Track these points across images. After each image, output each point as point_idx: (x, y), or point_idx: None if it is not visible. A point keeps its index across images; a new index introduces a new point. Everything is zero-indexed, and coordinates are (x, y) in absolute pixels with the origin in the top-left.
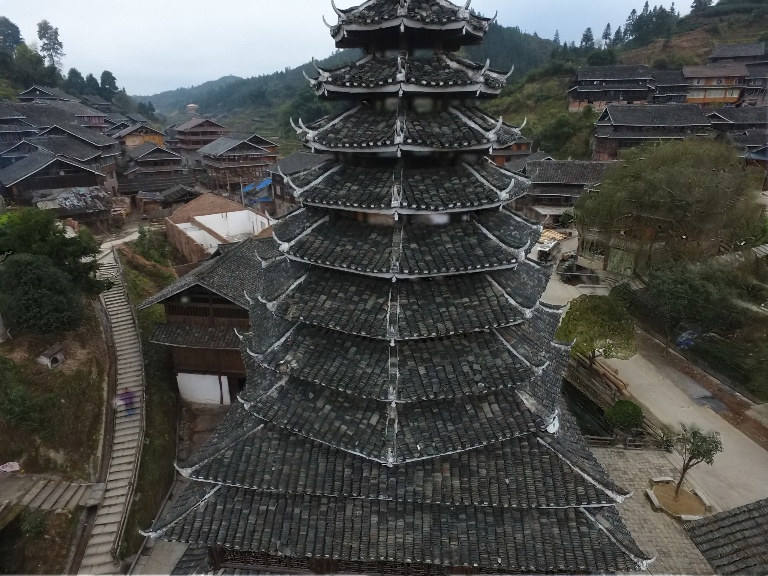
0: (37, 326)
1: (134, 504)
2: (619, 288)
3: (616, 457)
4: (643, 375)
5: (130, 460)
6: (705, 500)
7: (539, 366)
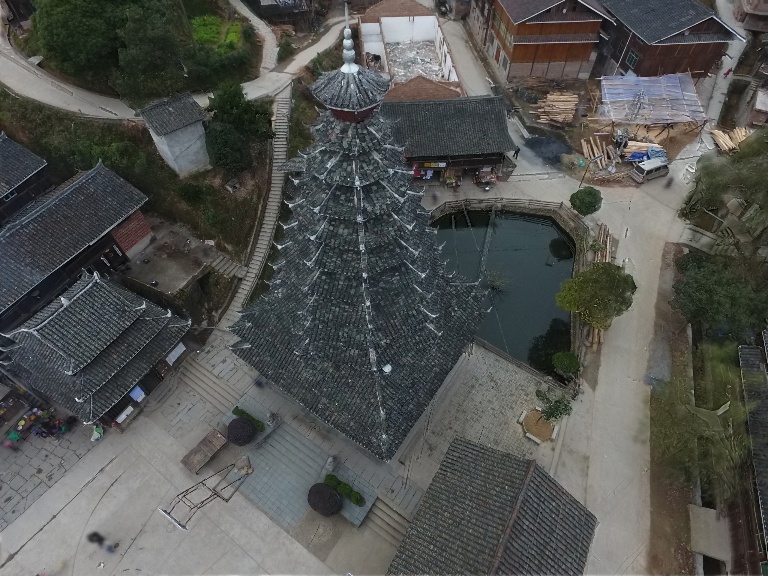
0: (225, 168)
1: (257, 285)
2: (689, 257)
3: (533, 383)
4: (632, 340)
5: (261, 260)
6: (554, 434)
7: (370, 348)
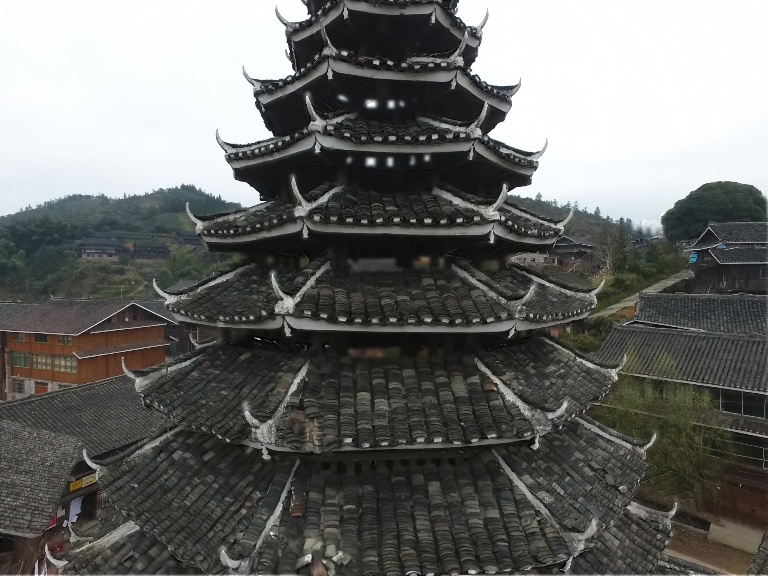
0: None
1: None
2: None
3: None
4: None
5: None
6: None
7: (644, 445)
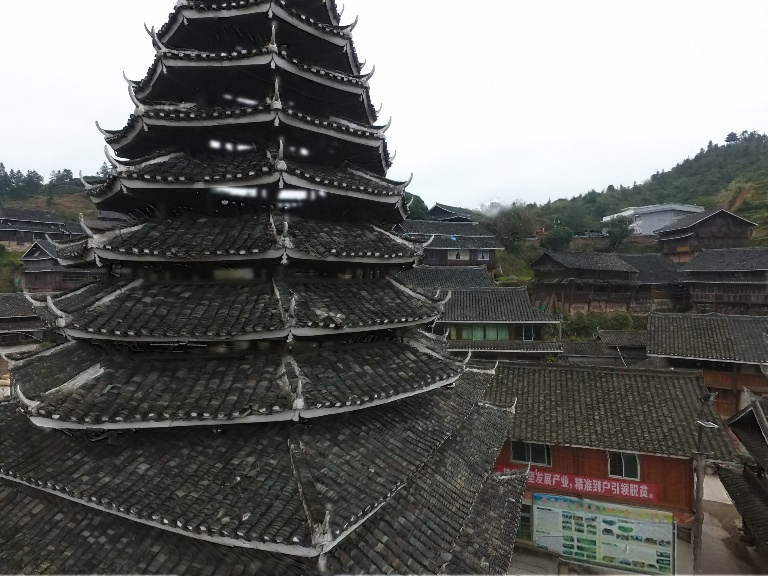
0: None
1: None
2: None
3: None
4: None
5: None
6: None
7: None
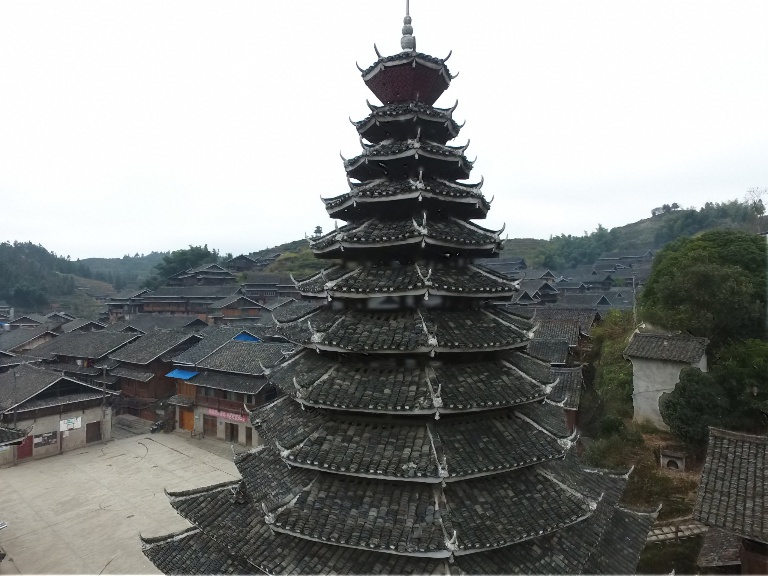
0: None
1: None
2: None
3: None
4: None
5: None
6: None
7: None
